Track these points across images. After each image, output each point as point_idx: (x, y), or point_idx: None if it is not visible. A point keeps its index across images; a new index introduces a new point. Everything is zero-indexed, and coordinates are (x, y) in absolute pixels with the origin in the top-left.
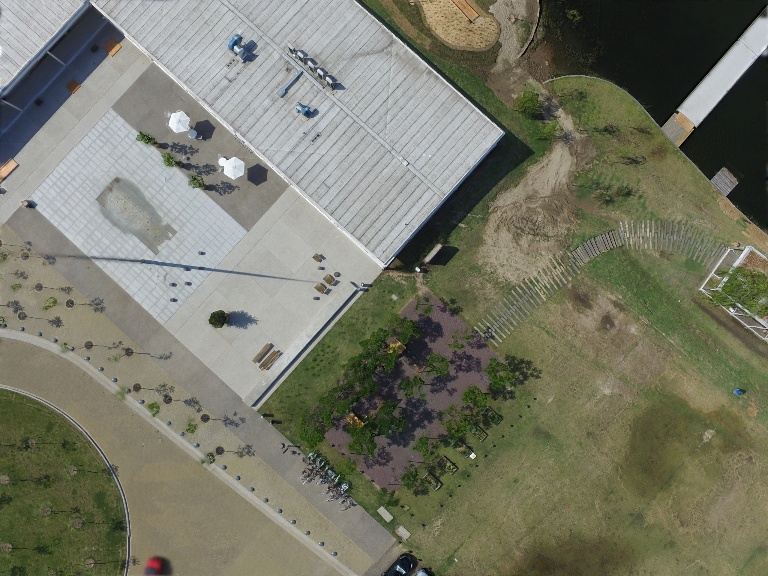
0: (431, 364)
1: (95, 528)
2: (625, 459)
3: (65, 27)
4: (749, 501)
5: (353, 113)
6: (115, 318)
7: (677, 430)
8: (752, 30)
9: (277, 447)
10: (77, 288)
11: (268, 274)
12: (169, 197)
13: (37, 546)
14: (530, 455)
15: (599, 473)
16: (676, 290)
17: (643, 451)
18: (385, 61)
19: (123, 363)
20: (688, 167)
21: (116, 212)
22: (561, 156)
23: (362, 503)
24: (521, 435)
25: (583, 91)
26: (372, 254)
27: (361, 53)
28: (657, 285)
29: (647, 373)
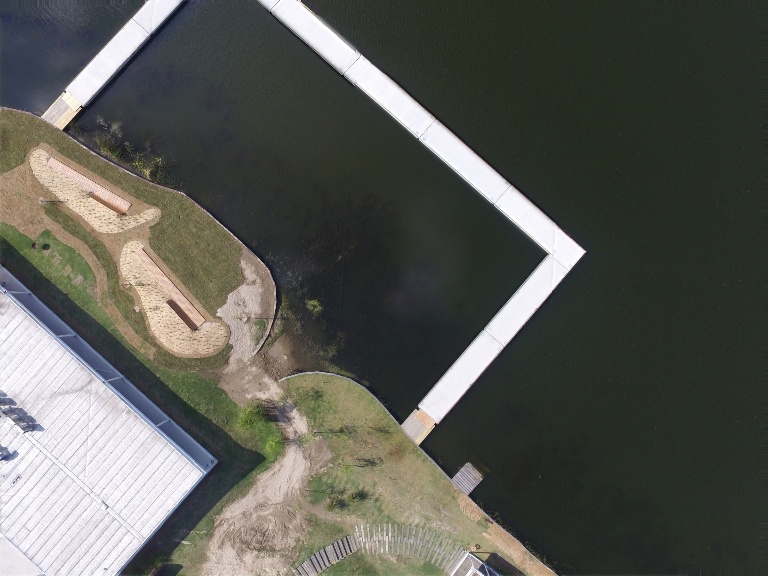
0: None
1: None
2: None
3: None
4: None
5: (52, 455)
6: None
7: None
8: (499, 318)
9: None
10: None
11: None
12: None
13: None
14: None
15: None
16: None
17: None
18: (84, 400)
19: None
20: (428, 466)
21: None
22: (294, 460)
23: None
24: None
25: (319, 390)
26: None
27: (60, 392)
28: None
29: None
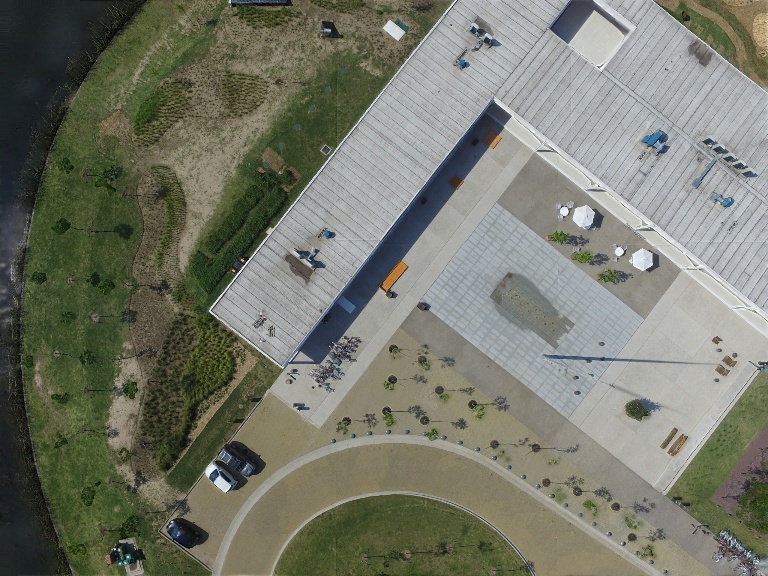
0: None
1: None
2: None
3: (470, 127)
4: None
5: (767, 200)
6: (519, 415)
7: None
8: None
9: (687, 528)
10: (479, 388)
11: (667, 360)
12: (563, 289)
13: None
14: None
15: None
16: None
17: None
18: None
19: (531, 459)
20: None
21: (511, 308)
22: None
23: None
24: None
25: None
26: None
27: None
28: None
29: None
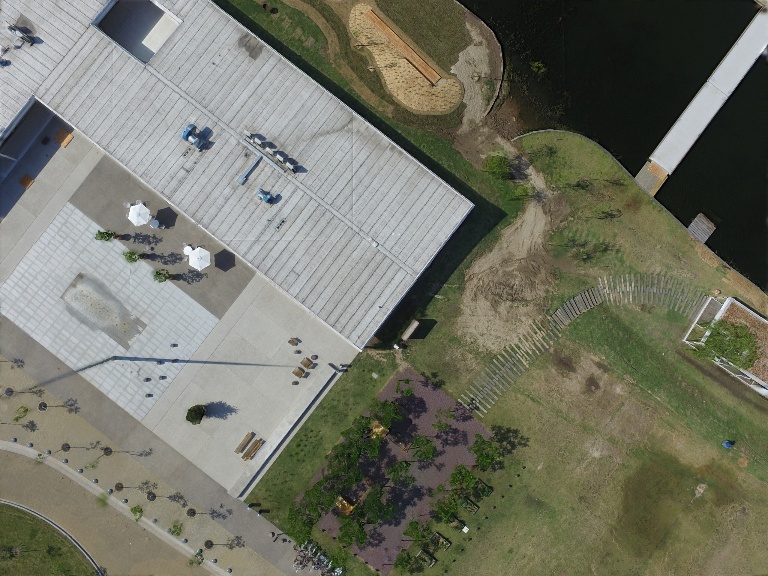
0: None
1: None
2: (618, 520)
3: (11, 126)
4: (745, 552)
5: (317, 196)
6: (90, 418)
7: (669, 487)
8: (721, 70)
9: (267, 536)
10: (49, 390)
11: (244, 362)
12: (136, 290)
13: None
14: (523, 524)
15: (593, 536)
16: (659, 343)
17: (636, 511)
18: (346, 139)
19: (103, 463)
20: (664, 216)
21: (82, 309)
22: (535, 215)
23: None
24: (512, 505)
25: (553, 146)
26: (347, 340)
27: (321, 133)
28: (640, 340)
29: (635, 432)
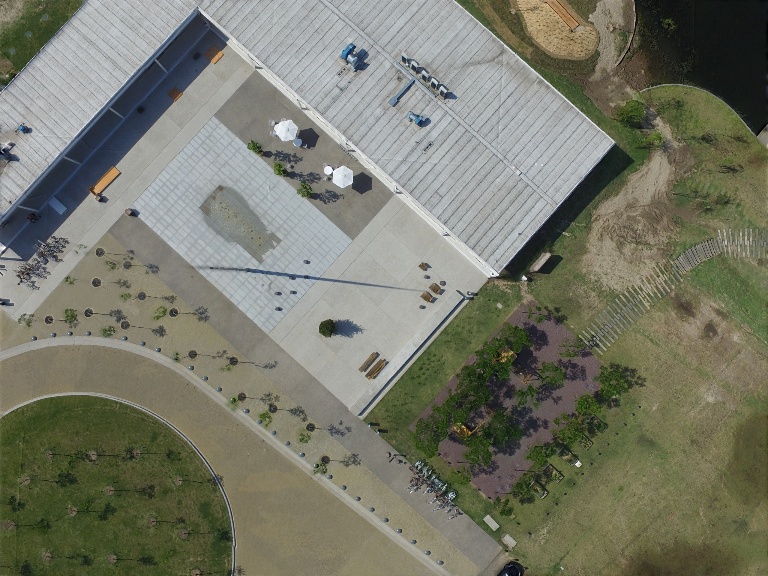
0: (536, 372)
1: (201, 538)
2: (729, 466)
3: (174, 35)
4: None
5: (465, 122)
6: (219, 327)
7: None
8: None
9: (383, 456)
10: (181, 297)
11: (373, 283)
12: (273, 205)
13: (142, 557)
14: (635, 463)
15: (703, 480)
16: None
17: (746, 458)
18: (496, 70)
19: (228, 372)
20: None
21: (220, 220)
22: (660, 165)
23: (468, 512)
24: (626, 443)
25: (680, 100)
26: (486, 263)
27: (472, 62)
28: (755, 293)
29: (750, 381)
